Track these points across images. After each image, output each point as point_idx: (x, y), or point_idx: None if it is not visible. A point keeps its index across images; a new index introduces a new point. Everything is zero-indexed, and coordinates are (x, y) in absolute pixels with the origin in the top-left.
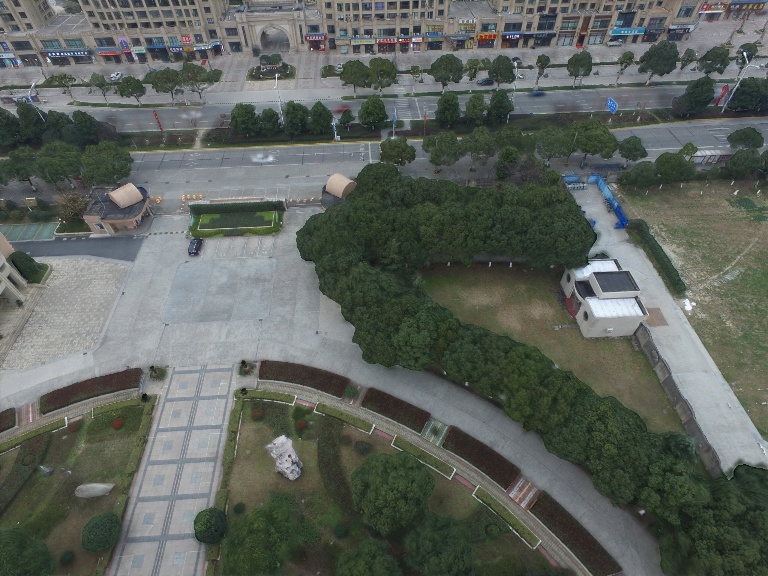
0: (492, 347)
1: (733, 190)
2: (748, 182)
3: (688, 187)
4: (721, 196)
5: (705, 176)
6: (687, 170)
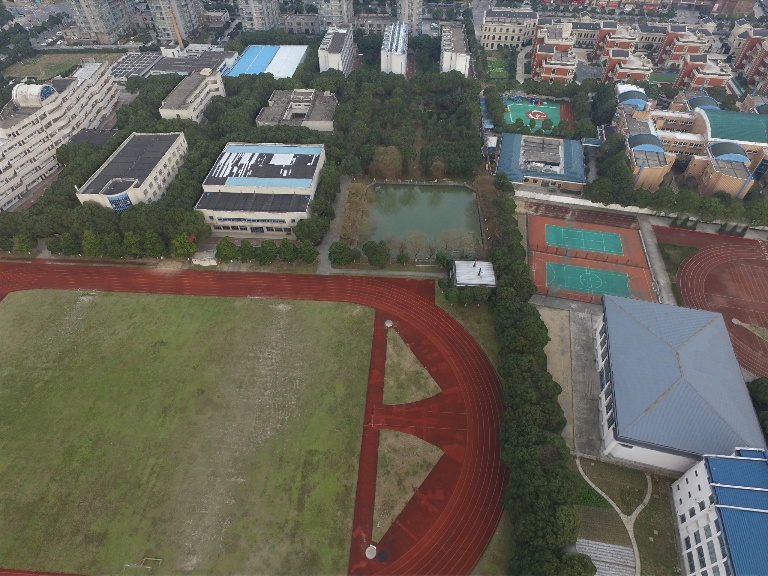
0: (10, 86)
1: (21, 64)
2: (22, 61)
3: (9, 69)
4: (20, 66)
5: (9, 64)
6: (1, 62)
